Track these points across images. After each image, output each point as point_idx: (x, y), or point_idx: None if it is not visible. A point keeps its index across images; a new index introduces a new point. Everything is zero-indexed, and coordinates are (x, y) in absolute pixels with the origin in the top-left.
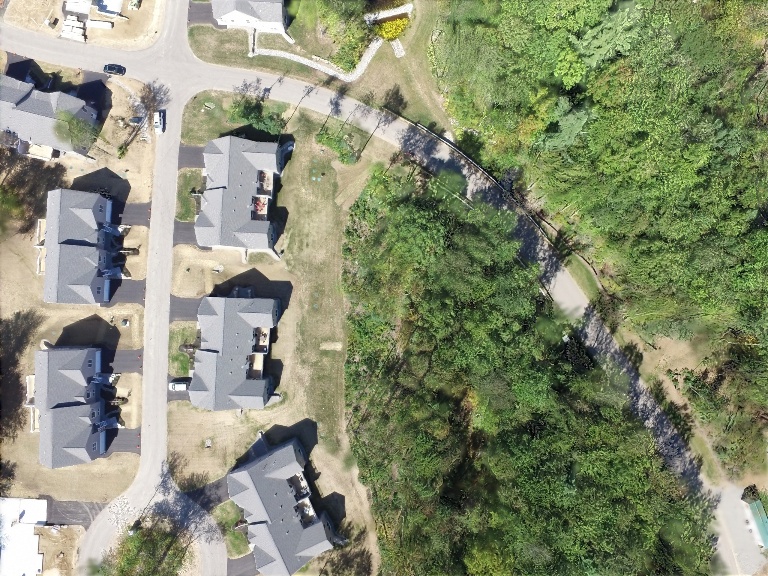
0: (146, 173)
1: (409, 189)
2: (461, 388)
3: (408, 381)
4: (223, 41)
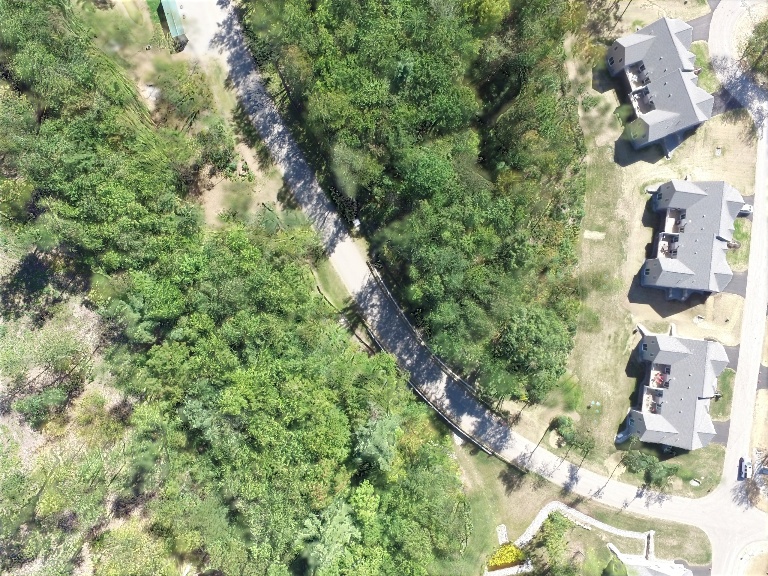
0: (760, 418)
1: (504, 387)
2: (506, 179)
3: (522, 194)
4: (679, 548)
